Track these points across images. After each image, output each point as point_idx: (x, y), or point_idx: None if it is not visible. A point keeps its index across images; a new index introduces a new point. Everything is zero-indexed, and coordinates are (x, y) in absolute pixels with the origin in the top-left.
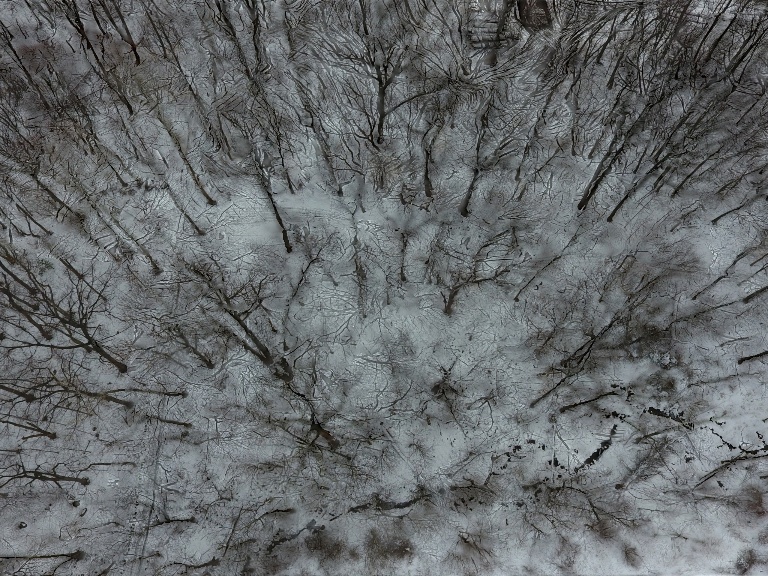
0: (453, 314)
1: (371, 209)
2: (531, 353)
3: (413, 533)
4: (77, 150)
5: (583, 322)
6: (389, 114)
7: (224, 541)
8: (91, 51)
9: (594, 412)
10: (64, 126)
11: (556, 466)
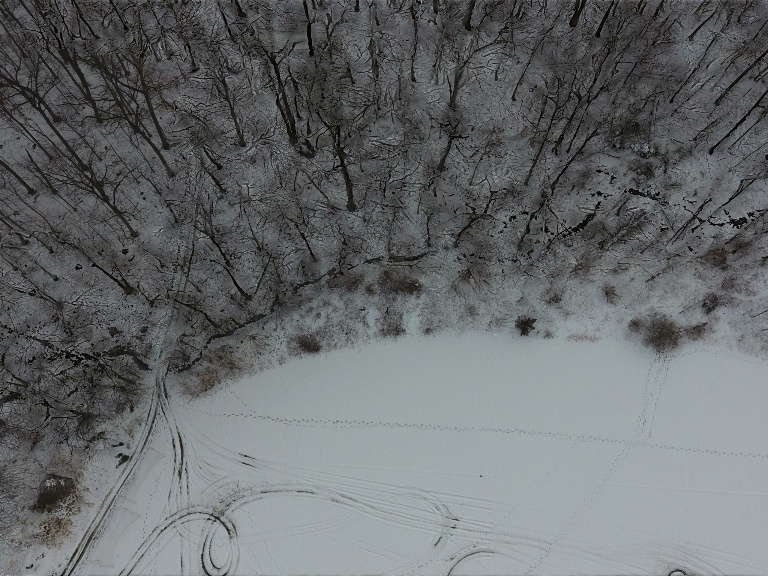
0: (457, 108)
1: (385, 22)
2: (526, 141)
3: (421, 275)
4: None
5: (573, 119)
6: None
7: (255, 282)
8: None
9: (581, 191)
10: None
11: (547, 232)
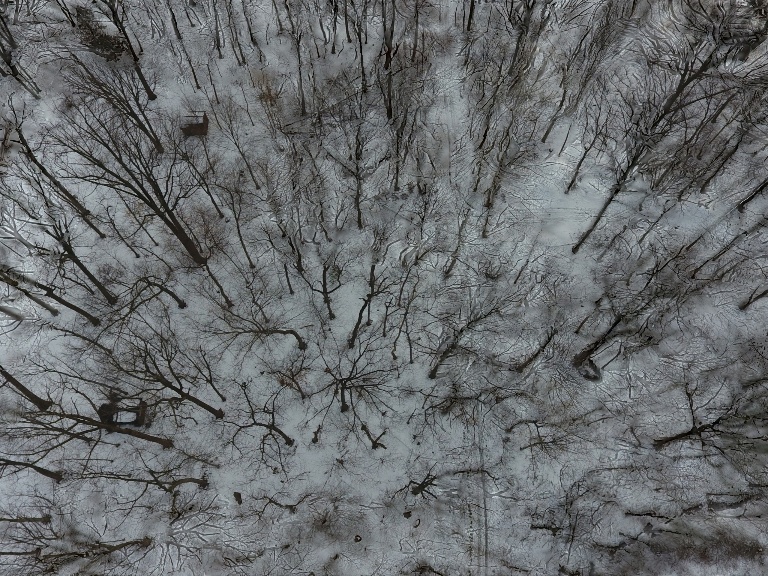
0: (749, 311)
1: (648, 207)
2: None
3: (759, 533)
4: (342, 155)
5: None
6: (676, 111)
7: (565, 548)
8: (335, 55)
9: None
10: (324, 131)
11: None
